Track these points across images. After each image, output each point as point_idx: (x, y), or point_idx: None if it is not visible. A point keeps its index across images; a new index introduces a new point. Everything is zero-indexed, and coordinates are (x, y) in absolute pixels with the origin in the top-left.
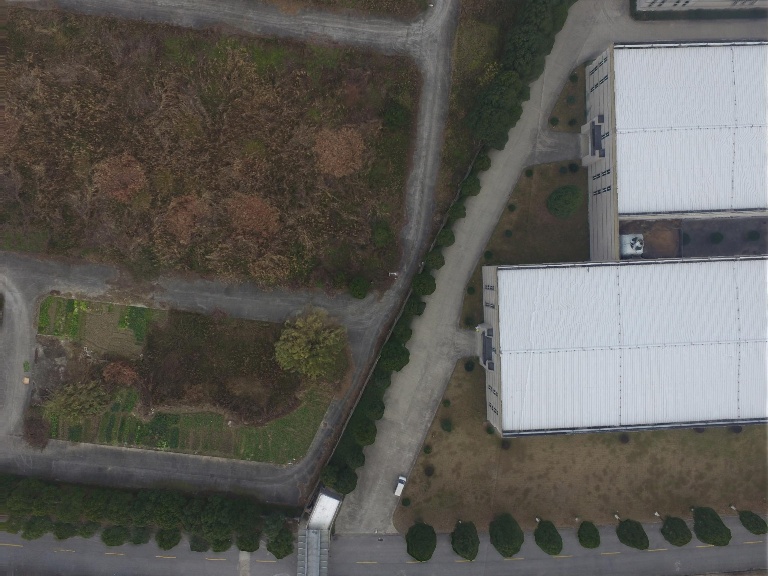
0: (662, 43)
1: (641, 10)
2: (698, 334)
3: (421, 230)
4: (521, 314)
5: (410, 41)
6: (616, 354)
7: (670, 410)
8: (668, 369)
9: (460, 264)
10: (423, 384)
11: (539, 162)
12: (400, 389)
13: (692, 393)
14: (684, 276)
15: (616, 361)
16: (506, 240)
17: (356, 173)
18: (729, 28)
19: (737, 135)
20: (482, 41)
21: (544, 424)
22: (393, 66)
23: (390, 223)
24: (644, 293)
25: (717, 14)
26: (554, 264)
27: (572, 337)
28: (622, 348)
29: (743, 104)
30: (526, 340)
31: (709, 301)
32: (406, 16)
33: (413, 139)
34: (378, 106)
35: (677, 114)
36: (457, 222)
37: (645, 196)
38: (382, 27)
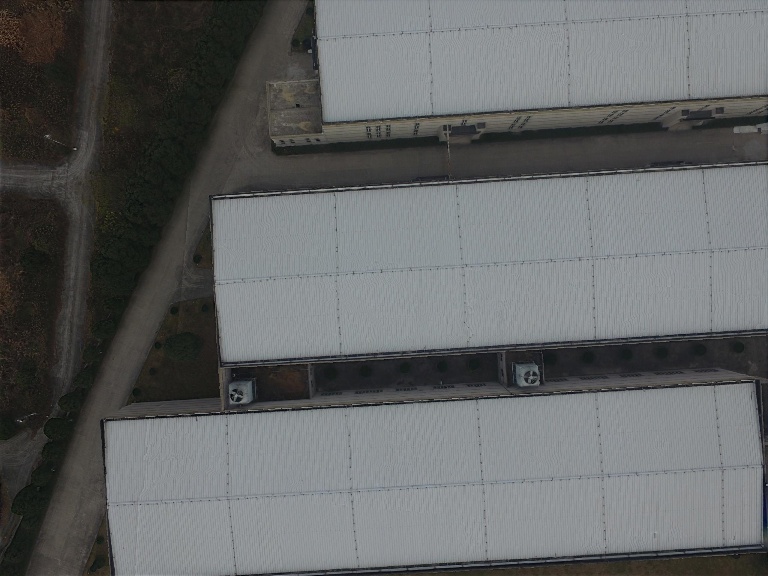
0: (262, 192)
1: (280, 146)
2: (308, 484)
3: (71, 368)
4: (129, 465)
5: (55, 184)
6: (225, 505)
7: (286, 560)
8: (280, 519)
9: (110, 401)
10: (78, 520)
11: (186, 298)
12: (56, 525)
13: (307, 543)
14: (294, 424)
15: (225, 512)
16: (154, 377)
17: (3, 315)
18: (374, 159)
19: (339, 282)
20: (97, 192)
21: (159, 574)
22: (39, 209)
23: (38, 363)
24: (253, 442)
25: (358, 146)
26: (160, 415)
27: (179, 488)
28: (230, 499)
29: (345, 251)
30: (138, 490)
31: (320, 449)
32: (50, 161)
33: (60, 280)
34: (19, 251)
35: (277, 263)
36: (106, 360)
37: (251, 345)
38: (28, 172)
